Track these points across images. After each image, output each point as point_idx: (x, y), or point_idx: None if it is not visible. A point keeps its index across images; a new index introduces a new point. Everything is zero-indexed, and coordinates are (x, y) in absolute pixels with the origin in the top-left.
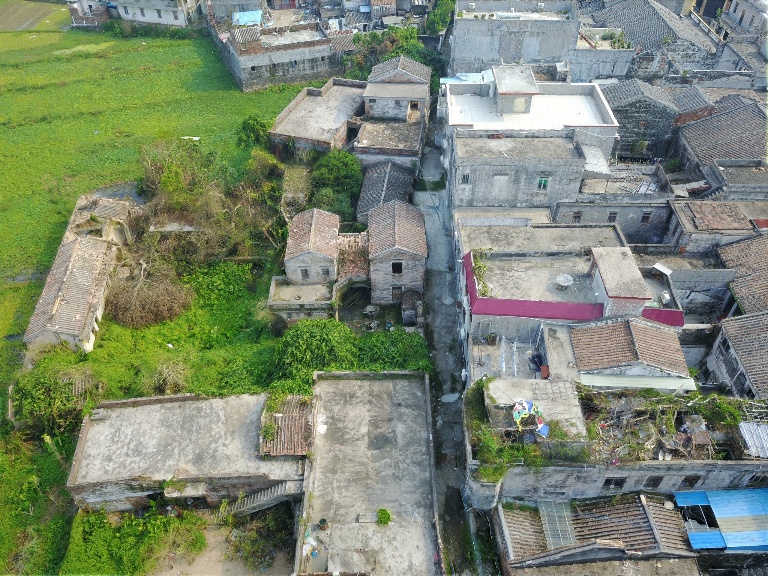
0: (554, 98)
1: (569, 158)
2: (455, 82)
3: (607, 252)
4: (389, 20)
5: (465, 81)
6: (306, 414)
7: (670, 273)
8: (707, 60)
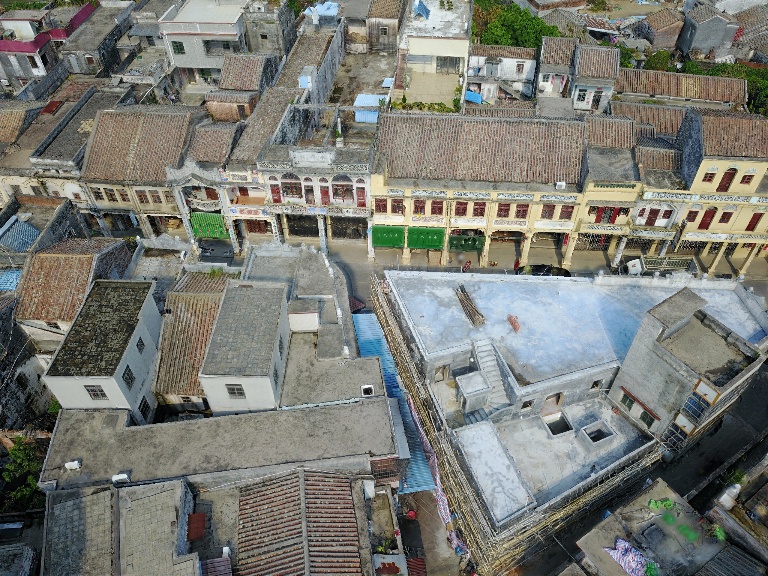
0: None
1: (135, 7)
2: (326, 7)
3: (42, 13)
4: (635, 42)
5: (325, 9)
6: None
7: (23, 41)
8: (329, 128)
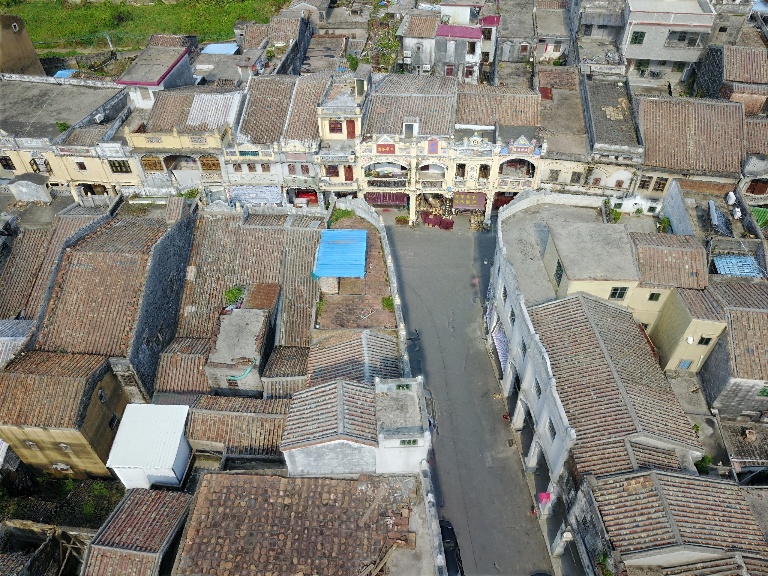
0: (695, 8)
1: None
2: None
3: None
4: None
5: None
6: (427, 1)
7: (472, 27)
8: None
